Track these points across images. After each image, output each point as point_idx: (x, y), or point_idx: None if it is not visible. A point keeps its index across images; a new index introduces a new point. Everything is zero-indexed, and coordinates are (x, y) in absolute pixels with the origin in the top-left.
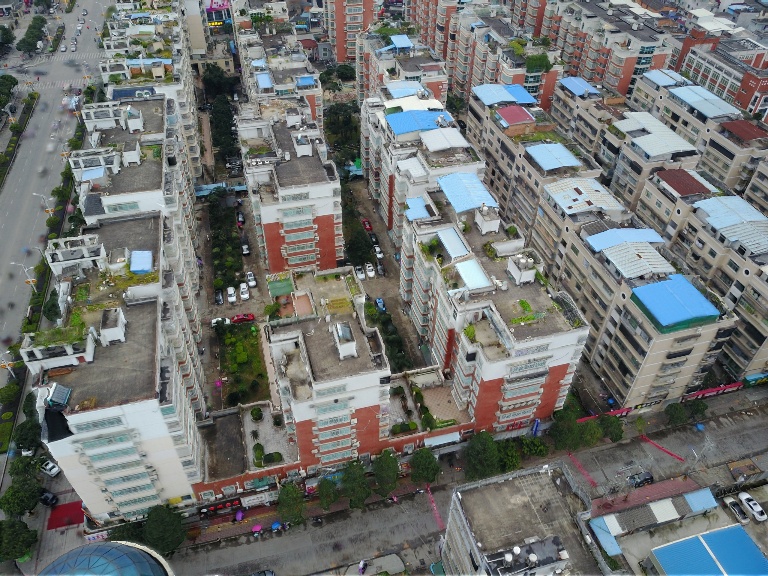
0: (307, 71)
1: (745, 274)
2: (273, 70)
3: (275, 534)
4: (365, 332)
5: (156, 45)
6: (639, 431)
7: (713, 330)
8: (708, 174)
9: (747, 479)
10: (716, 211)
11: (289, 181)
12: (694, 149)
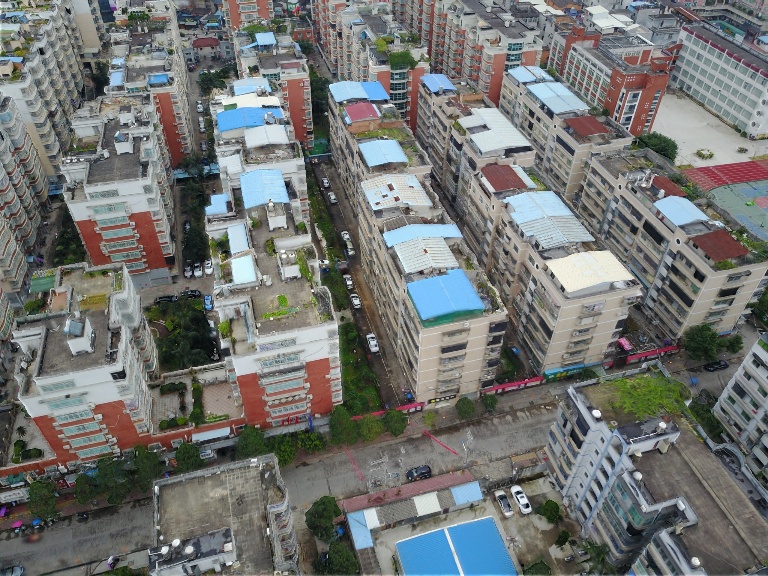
0: (164, 69)
1: (536, 269)
2: (130, 68)
3: (37, 530)
4: (110, 328)
5: (14, 43)
6: (432, 426)
7: (484, 324)
8: (535, 170)
9: (521, 472)
10: (522, 206)
11: (99, 178)
12: (528, 145)
